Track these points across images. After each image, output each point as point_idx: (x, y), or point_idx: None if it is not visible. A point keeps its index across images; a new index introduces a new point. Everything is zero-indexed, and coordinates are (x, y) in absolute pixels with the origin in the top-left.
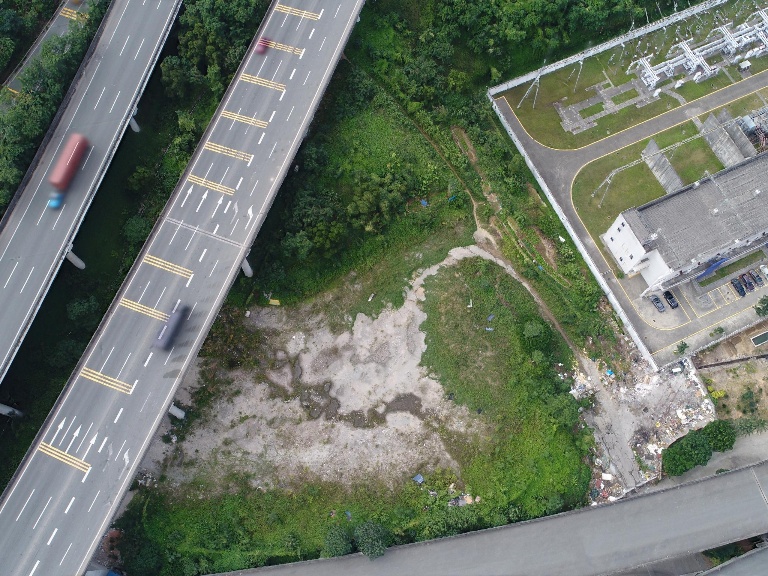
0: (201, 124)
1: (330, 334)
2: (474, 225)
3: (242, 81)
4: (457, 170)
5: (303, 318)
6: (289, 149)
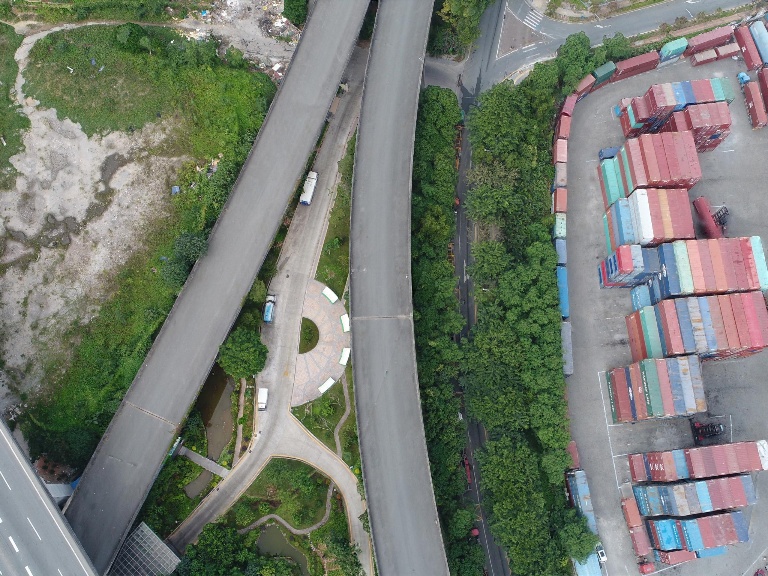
0: None
1: (9, 192)
2: (8, 27)
3: None
4: None
5: None
6: None
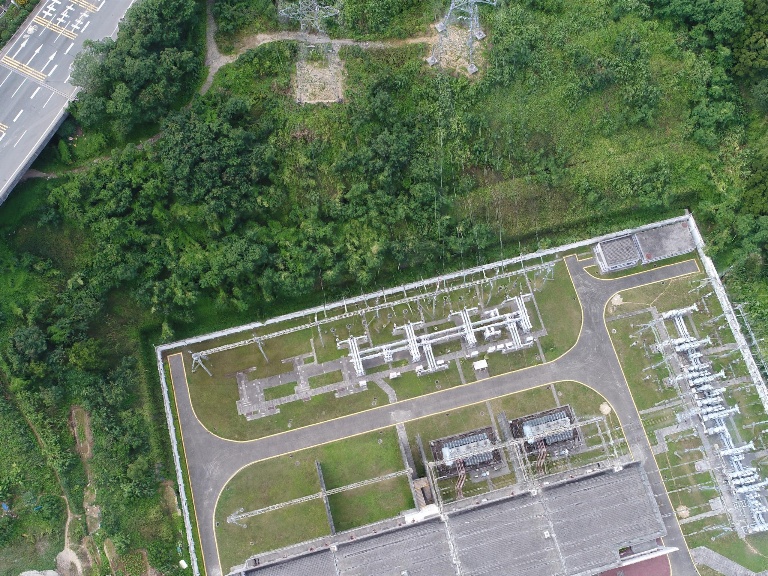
0: None
1: None
2: (61, 544)
3: None
4: None
5: None
6: None
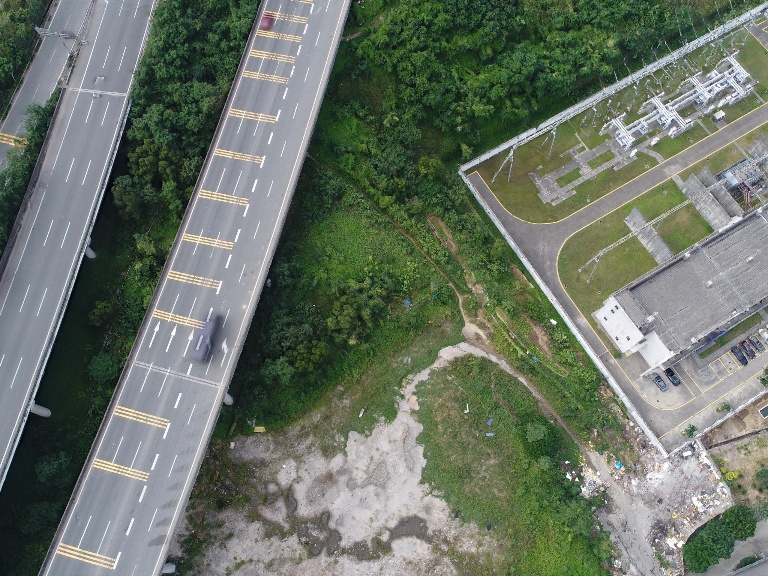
0: (161, 246)
1: (322, 458)
2: (462, 321)
3: (201, 198)
4: (438, 263)
5: (292, 444)
6: (259, 271)
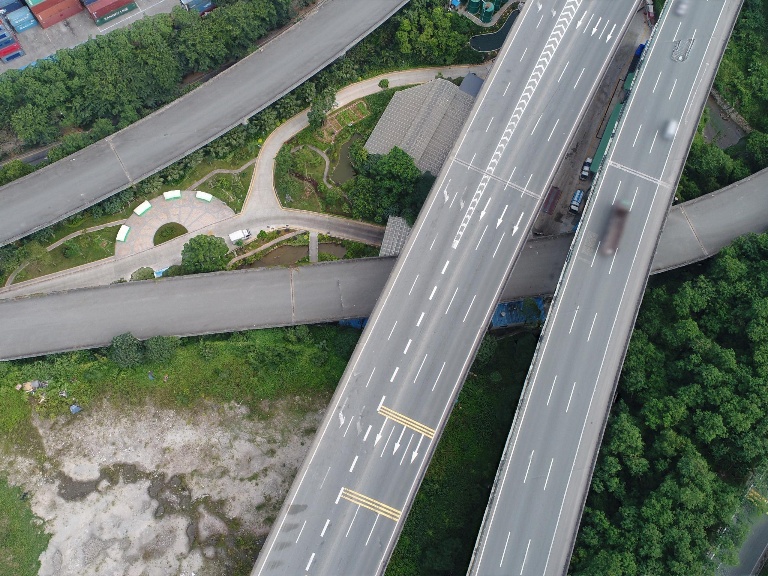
0: None
1: None
2: None
3: None
4: None
5: None
6: None
